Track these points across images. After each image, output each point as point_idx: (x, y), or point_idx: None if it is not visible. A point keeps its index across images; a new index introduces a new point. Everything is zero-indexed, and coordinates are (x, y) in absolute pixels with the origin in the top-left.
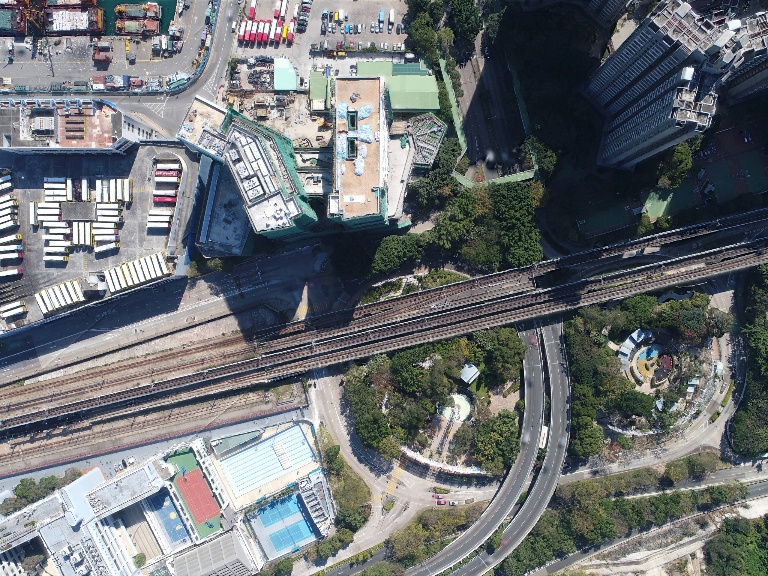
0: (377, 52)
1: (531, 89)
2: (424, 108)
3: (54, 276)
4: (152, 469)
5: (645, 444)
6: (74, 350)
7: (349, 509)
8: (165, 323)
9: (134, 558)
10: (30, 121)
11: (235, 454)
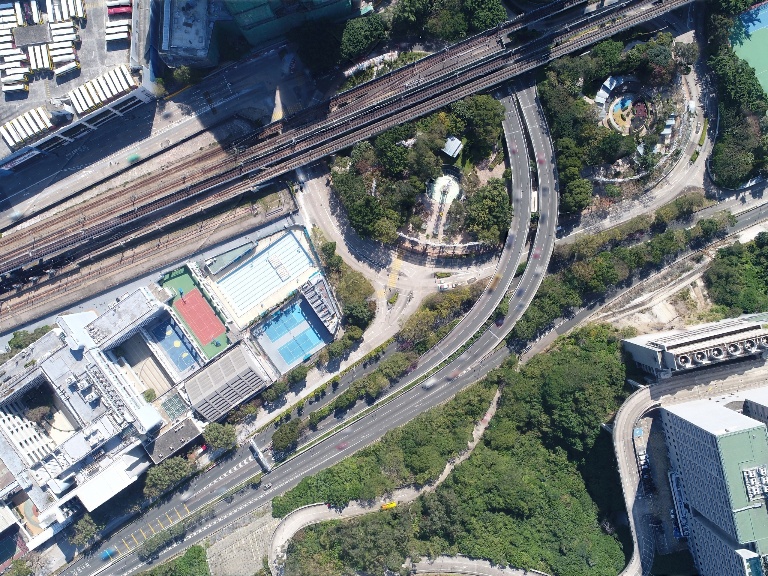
0: None
1: None
2: None
3: (16, 109)
4: (148, 292)
5: (632, 189)
6: (49, 194)
7: (354, 301)
8: (139, 151)
9: (144, 393)
10: None
11: (231, 274)
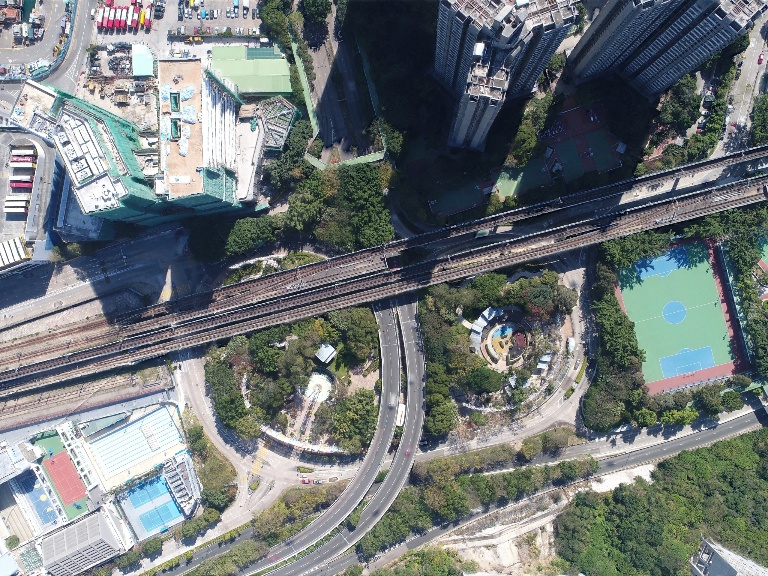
0: (233, 37)
1: (379, 71)
2: (277, 91)
3: None
4: (17, 452)
5: (498, 420)
6: None
7: (211, 488)
8: (33, 308)
9: (6, 540)
10: None
11: (104, 437)
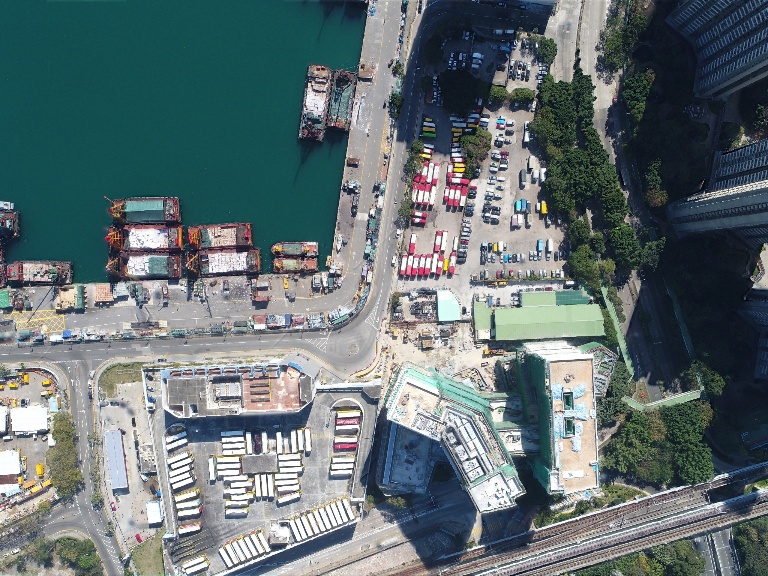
0: (537, 280)
1: (693, 315)
2: (590, 335)
3: (235, 526)
4: None
5: None
6: None
7: None
8: (340, 553)
9: None
10: (213, 386)
11: None
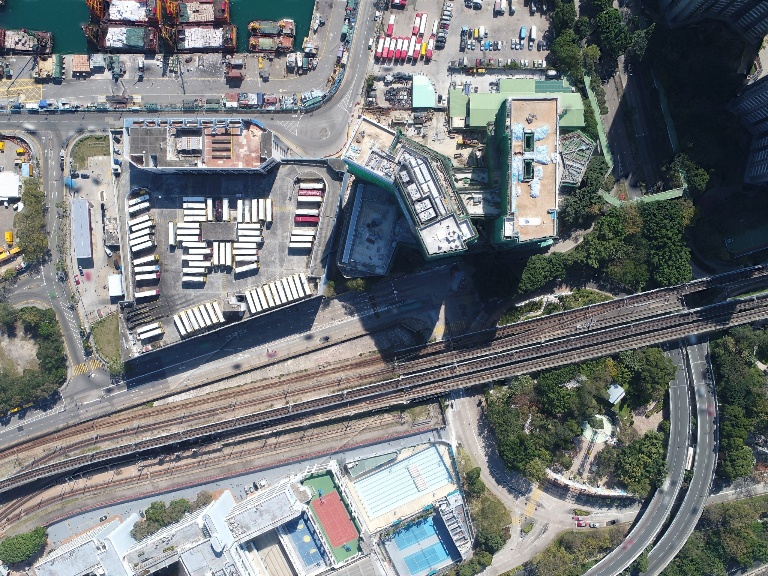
0: (518, 69)
1: (680, 106)
2: (569, 126)
3: (191, 297)
4: (291, 492)
5: None
6: (204, 371)
7: (492, 532)
8: (298, 343)
9: None
10: (175, 141)
11: (369, 476)
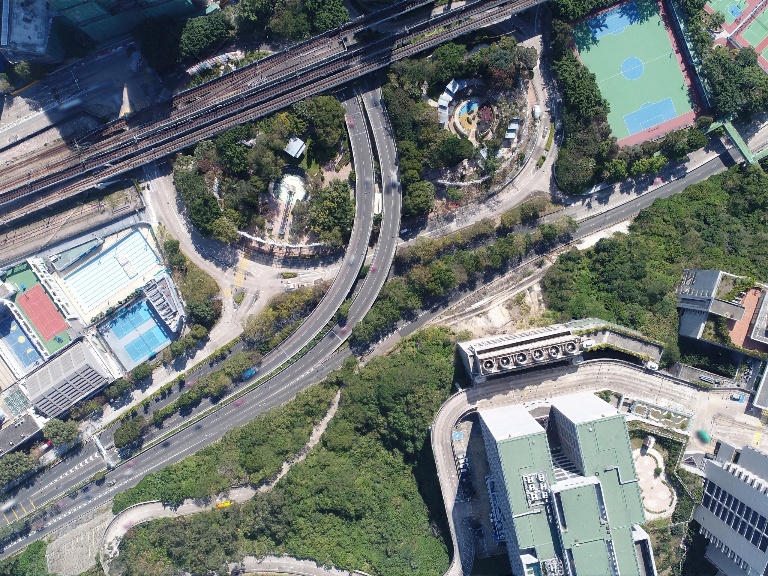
0: None
1: None
2: None
3: None
4: None
5: (475, 193)
6: None
7: (195, 300)
8: None
9: None
10: None
11: (78, 270)
